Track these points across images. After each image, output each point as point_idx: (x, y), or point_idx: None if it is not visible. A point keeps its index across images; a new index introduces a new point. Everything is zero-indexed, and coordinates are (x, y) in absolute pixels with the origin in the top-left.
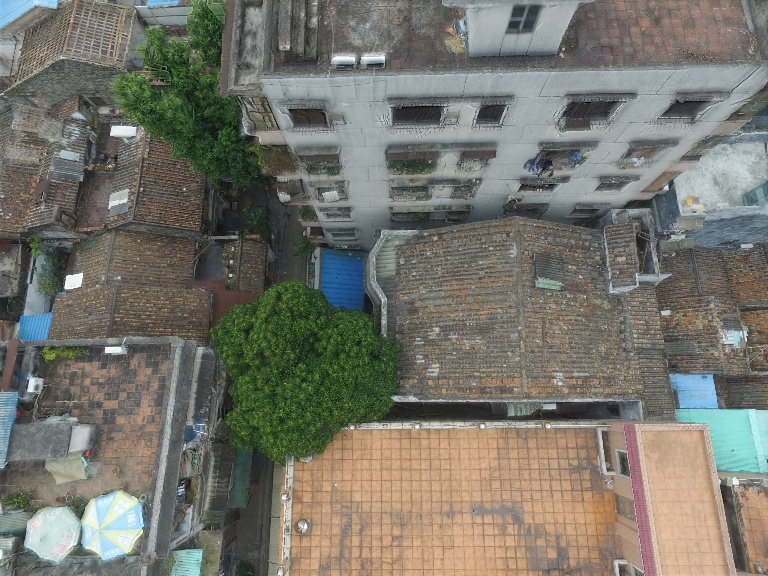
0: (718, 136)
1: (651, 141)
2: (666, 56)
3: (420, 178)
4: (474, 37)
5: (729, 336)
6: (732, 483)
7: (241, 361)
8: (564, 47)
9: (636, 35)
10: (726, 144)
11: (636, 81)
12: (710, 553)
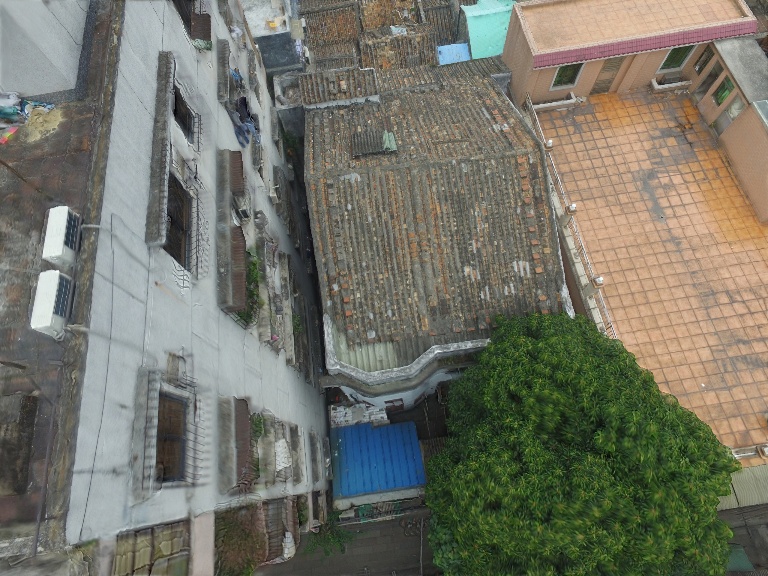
0: None
1: None
2: None
3: None
4: (37, 49)
5: (398, 31)
6: None
7: (612, 567)
8: None
9: None
10: None
11: None
12: (634, 1)
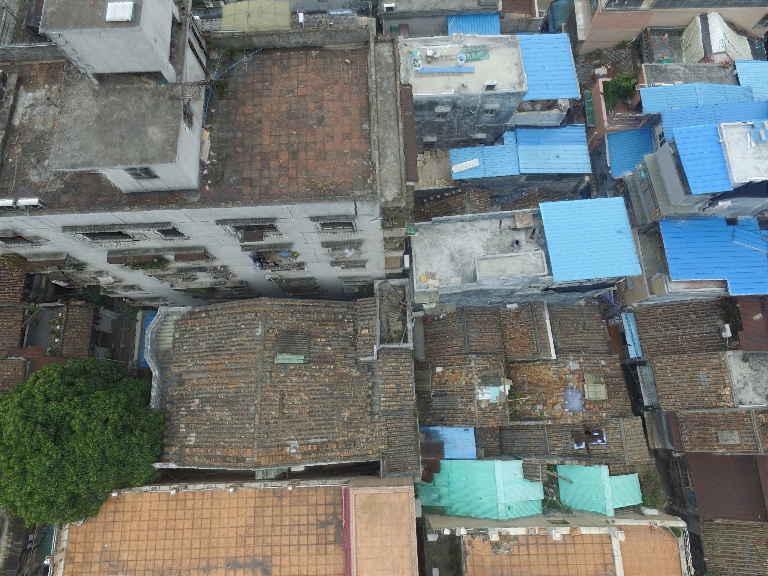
0: (393, 237)
1: (338, 242)
2: (297, 186)
3: (169, 267)
4: (112, 181)
5: (485, 392)
6: (460, 533)
7: None
8: (211, 179)
9: (274, 167)
10: (465, 222)
11: (263, 211)
12: None
